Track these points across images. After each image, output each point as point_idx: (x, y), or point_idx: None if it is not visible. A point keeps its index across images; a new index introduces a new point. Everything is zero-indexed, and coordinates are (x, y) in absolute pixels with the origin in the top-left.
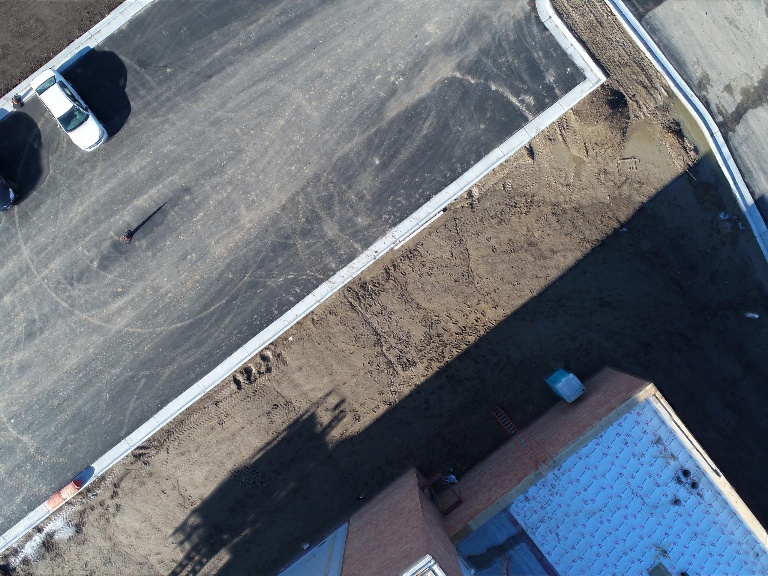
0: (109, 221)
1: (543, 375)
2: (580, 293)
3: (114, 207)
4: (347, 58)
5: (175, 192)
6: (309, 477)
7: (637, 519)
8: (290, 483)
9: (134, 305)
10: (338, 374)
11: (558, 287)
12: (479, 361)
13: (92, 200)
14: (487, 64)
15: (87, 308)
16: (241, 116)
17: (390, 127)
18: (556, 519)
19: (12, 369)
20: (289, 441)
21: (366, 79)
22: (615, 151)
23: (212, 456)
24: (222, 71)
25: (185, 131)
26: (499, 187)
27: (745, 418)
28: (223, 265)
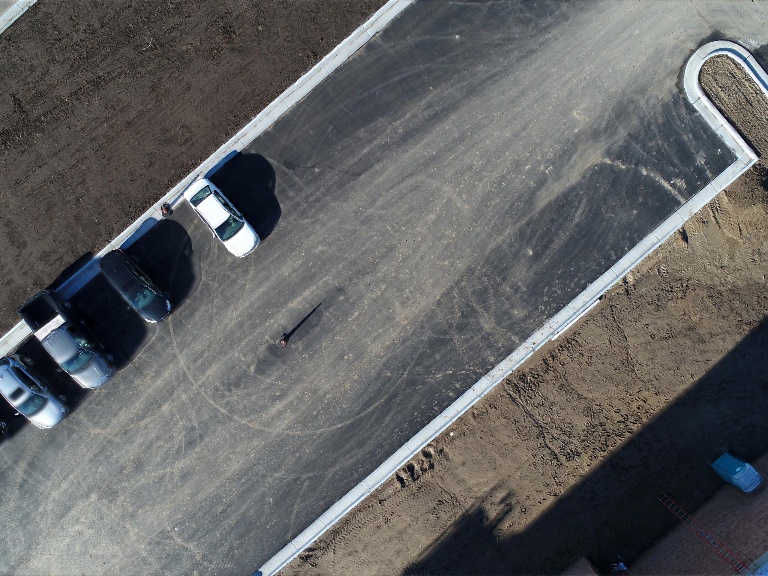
0: (264, 325)
1: (707, 459)
2: (740, 375)
3: (268, 311)
4: (496, 149)
5: (329, 293)
6: (477, 571)
7: None
8: None
9: (293, 408)
10: (502, 467)
11: (718, 370)
12: (642, 448)
13: (246, 305)
14: (637, 149)
15: (246, 413)
16: (392, 213)
17: (542, 217)
18: None
19: (174, 478)
20: (456, 536)
21: (516, 169)
22: None
23: (379, 555)
24: (371, 168)
25: (336, 231)
26: (654, 272)
27: None
28: (380, 364)
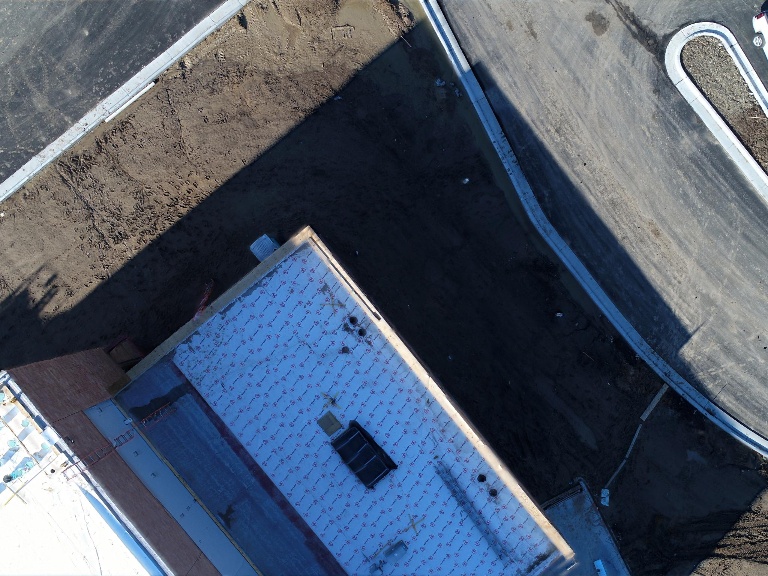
0: None
1: None
2: (293, 162)
3: None
4: None
5: None
6: (22, 354)
7: (304, 367)
8: (3, 361)
9: None
10: (49, 249)
11: (270, 156)
12: (192, 233)
13: None
14: None
15: None
16: None
17: None
18: (221, 369)
19: None
20: (1, 318)
21: None
22: (329, 18)
23: None
24: None
25: None
26: (211, 57)
27: (464, 286)
28: None
